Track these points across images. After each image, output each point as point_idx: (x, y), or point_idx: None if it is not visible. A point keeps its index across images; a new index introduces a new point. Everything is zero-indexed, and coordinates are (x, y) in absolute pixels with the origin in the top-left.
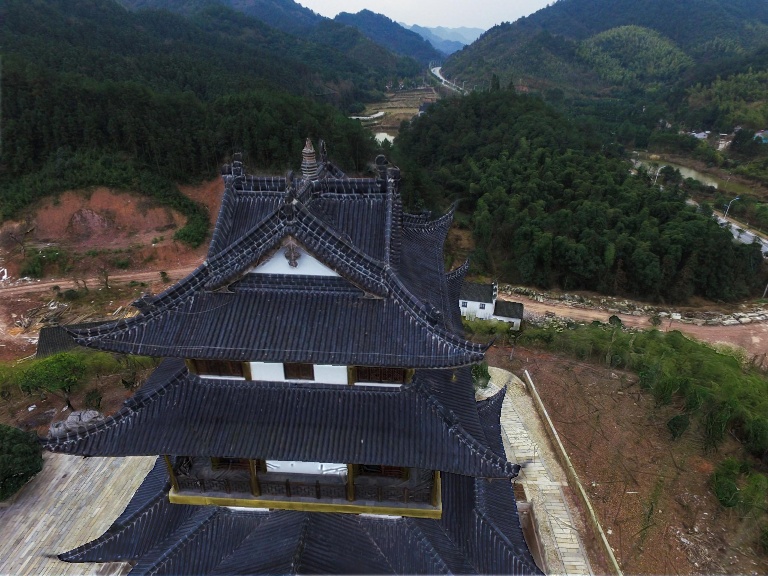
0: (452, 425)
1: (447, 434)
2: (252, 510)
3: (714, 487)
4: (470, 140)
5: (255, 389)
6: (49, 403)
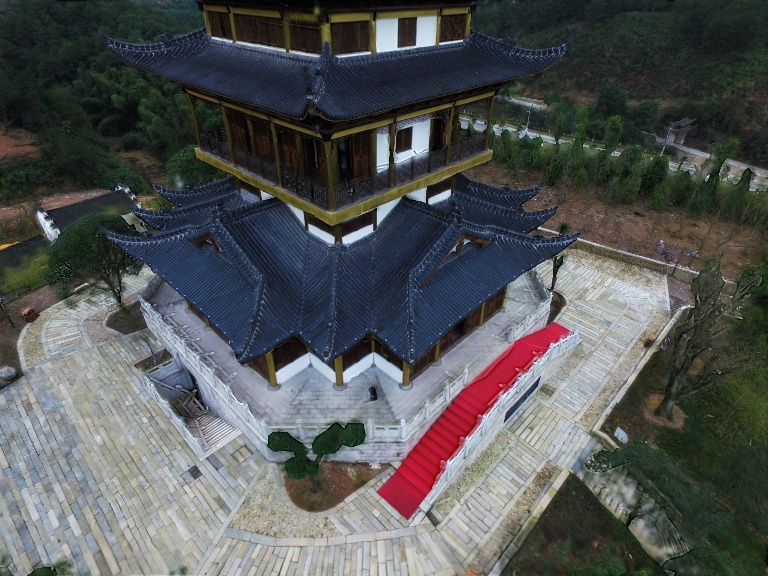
0: (512, 48)
1: (510, 57)
2: (361, 238)
3: (508, 174)
4: (70, 51)
5: (381, 62)
6: None
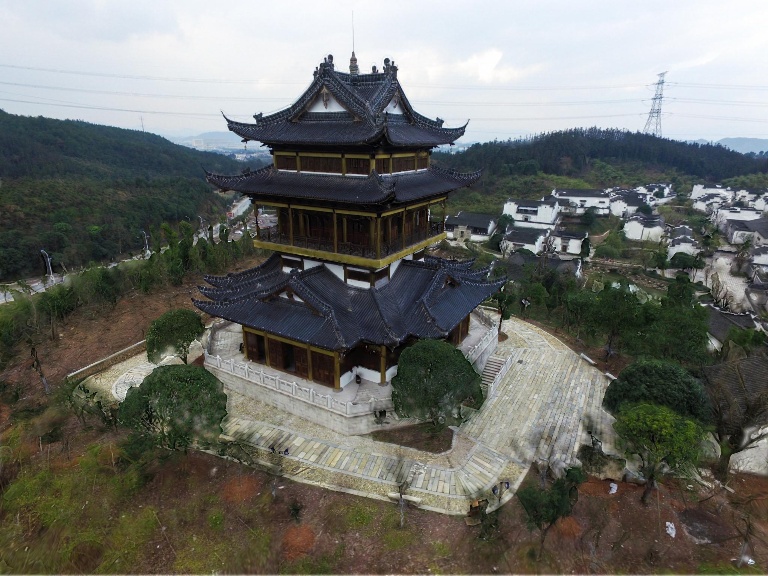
0: None
1: None
2: None
3: None
4: None
5: None
6: (720, 557)
